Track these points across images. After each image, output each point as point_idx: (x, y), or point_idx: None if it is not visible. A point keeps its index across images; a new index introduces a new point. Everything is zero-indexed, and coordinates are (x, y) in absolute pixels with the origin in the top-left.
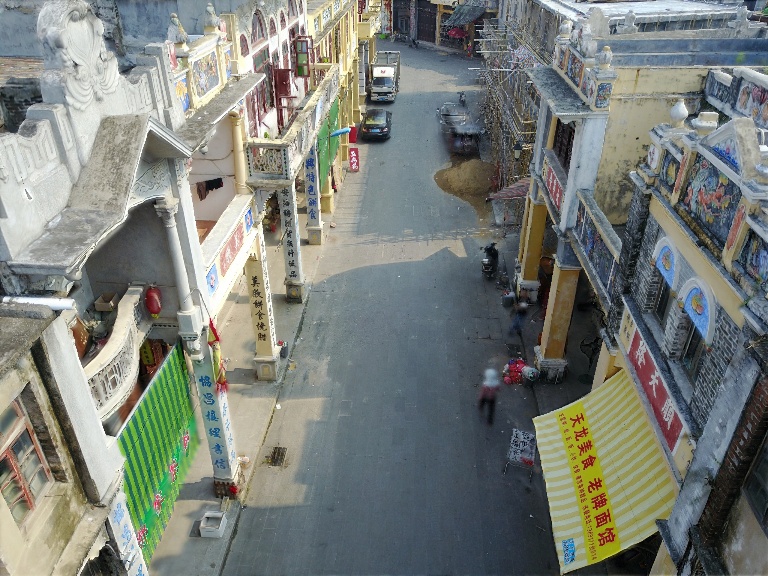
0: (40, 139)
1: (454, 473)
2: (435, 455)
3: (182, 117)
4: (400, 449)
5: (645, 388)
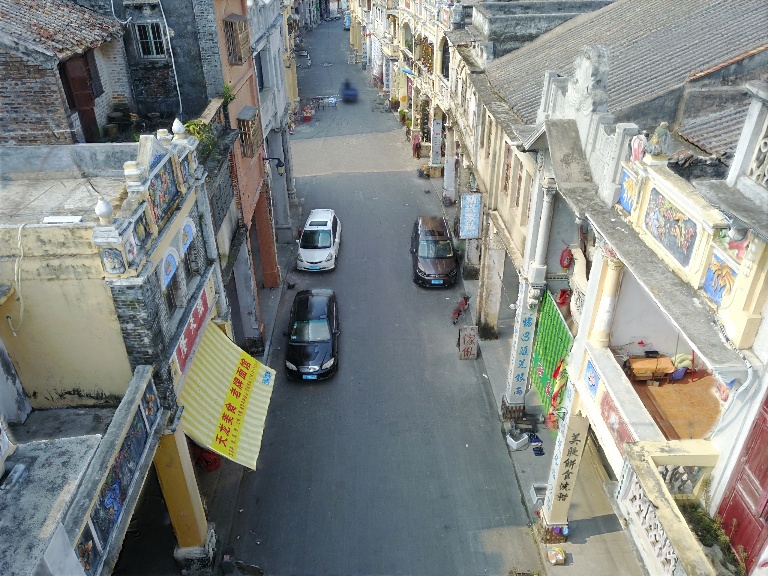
0: (563, 101)
1: None
2: None
3: (609, 199)
4: None
5: (193, 341)
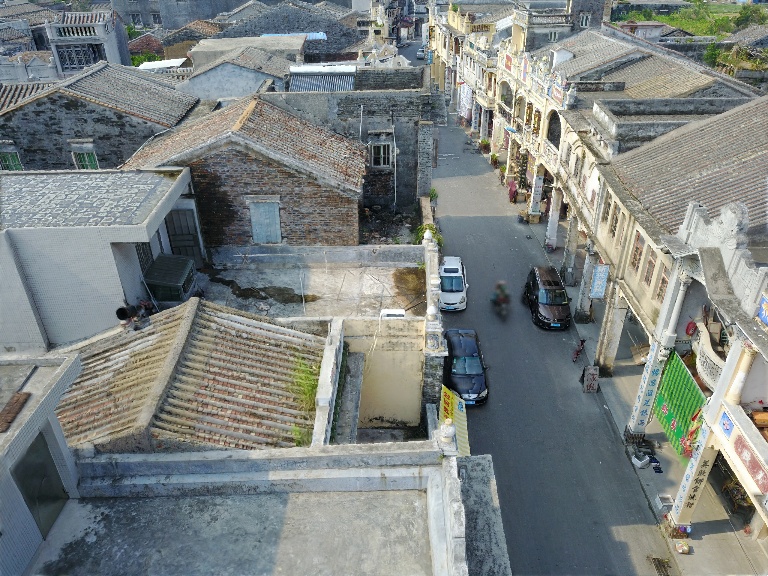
0: None
1: (516, 556)
2: (534, 571)
3: None
4: (564, 575)
5: None
